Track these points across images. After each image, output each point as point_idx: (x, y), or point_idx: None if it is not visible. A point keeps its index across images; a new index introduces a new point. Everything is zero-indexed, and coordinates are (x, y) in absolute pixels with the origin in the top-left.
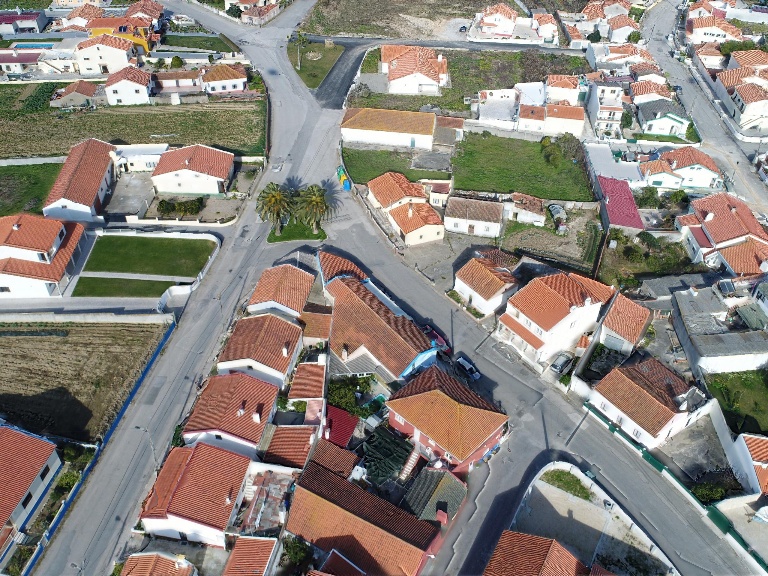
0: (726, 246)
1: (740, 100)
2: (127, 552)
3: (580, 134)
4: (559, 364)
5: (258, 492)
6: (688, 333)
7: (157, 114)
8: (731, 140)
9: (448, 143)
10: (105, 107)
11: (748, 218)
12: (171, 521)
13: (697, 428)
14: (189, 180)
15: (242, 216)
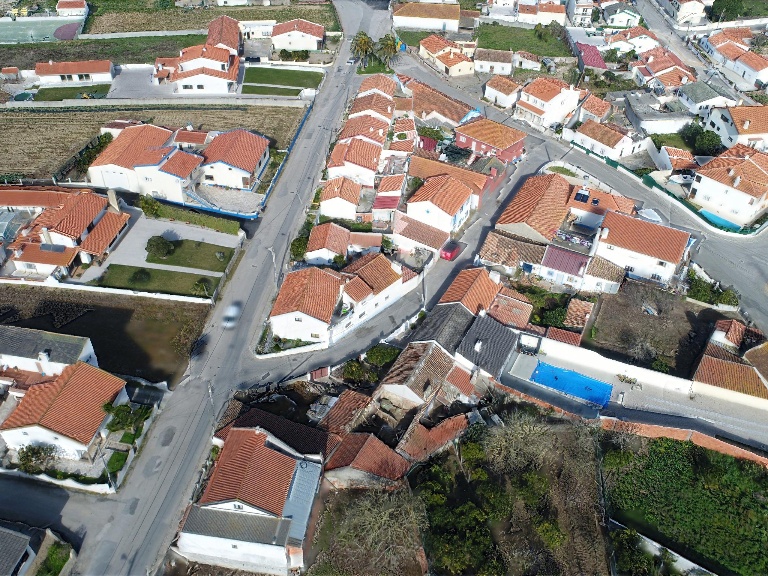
0: (661, 74)
1: (677, 3)
2: None
3: (562, 24)
4: (555, 125)
5: (389, 162)
6: (635, 113)
7: (255, 10)
8: (670, 29)
9: (470, 26)
10: (216, 7)
11: (676, 60)
12: (346, 167)
13: (639, 155)
14: (297, 39)
15: (335, 62)
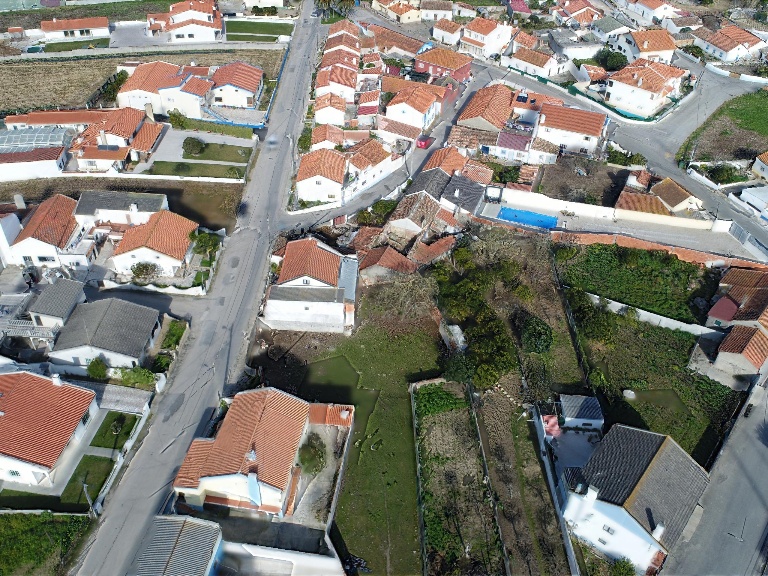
0: (576, 15)
1: None
2: None
3: None
4: (494, 55)
5: (364, 83)
6: (557, 43)
7: None
8: None
9: None
10: None
11: (588, 3)
12: (331, 87)
13: (563, 74)
14: None
15: (301, 16)
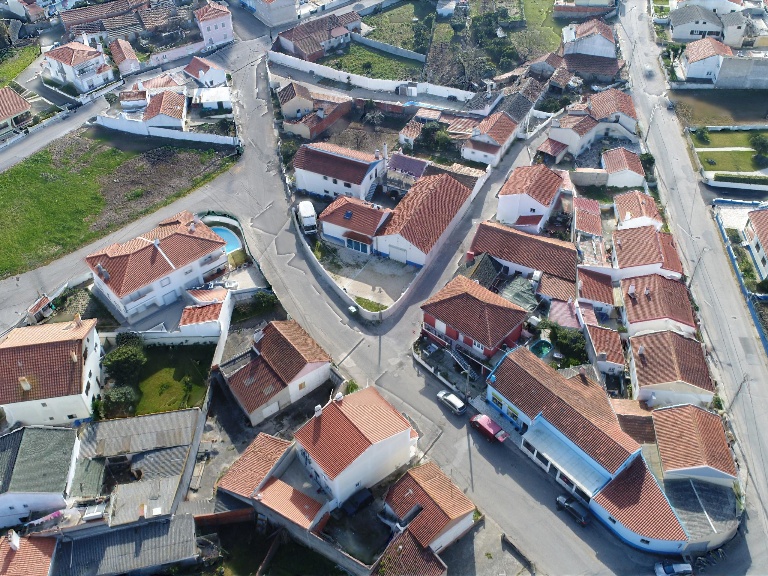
0: None
1: None
2: (671, 244)
3: None
4: None
5: (604, 259)
6: None
7: None
8: None
9: None
10: None
11: None
12: None
13: None
14: None
15: None
